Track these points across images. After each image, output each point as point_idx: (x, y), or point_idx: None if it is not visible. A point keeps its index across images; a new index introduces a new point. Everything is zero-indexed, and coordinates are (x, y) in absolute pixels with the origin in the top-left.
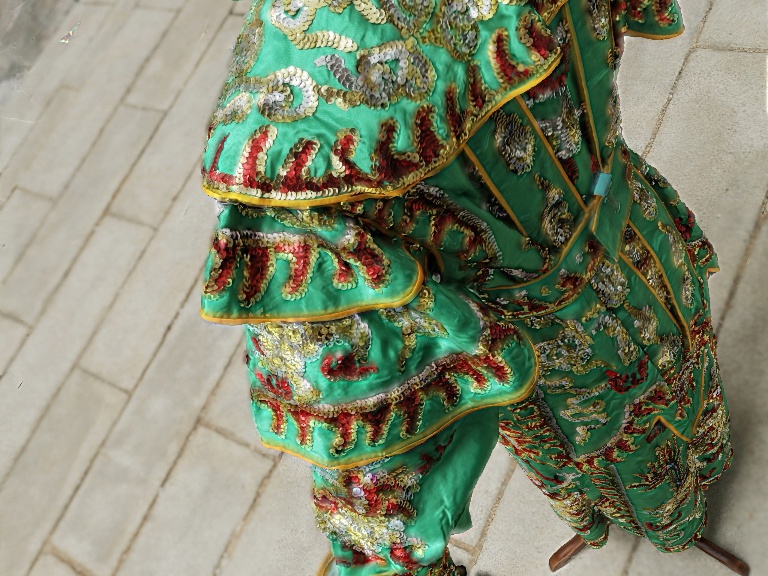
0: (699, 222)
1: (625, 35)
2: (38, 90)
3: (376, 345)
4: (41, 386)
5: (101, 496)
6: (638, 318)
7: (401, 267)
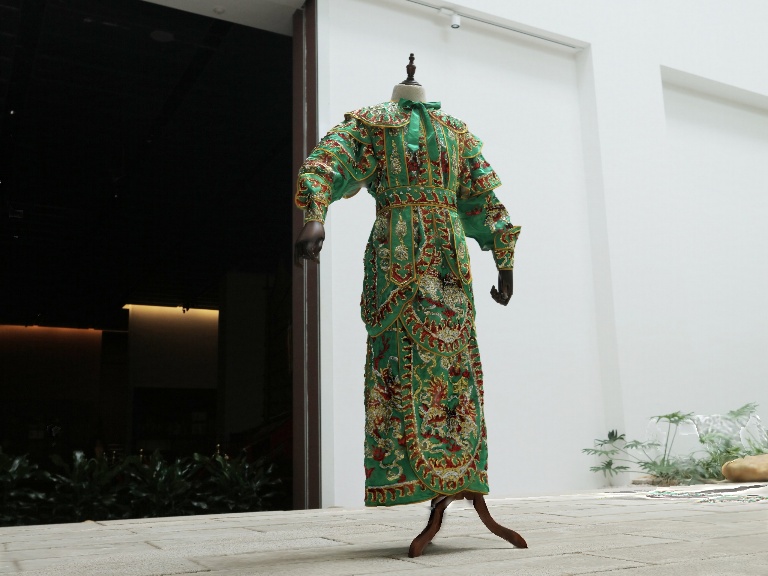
0: (247, 573)
1: None
2: None
3: None
4: None
5: None
6: None
7: None
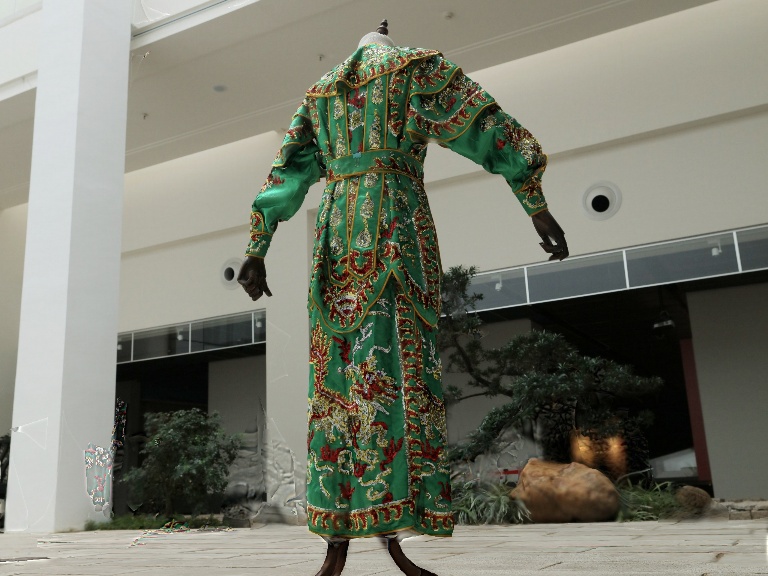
0: None
1: None
2: (761, 521)
3: None
4: None
5: None
6: (334, 209)
7: None
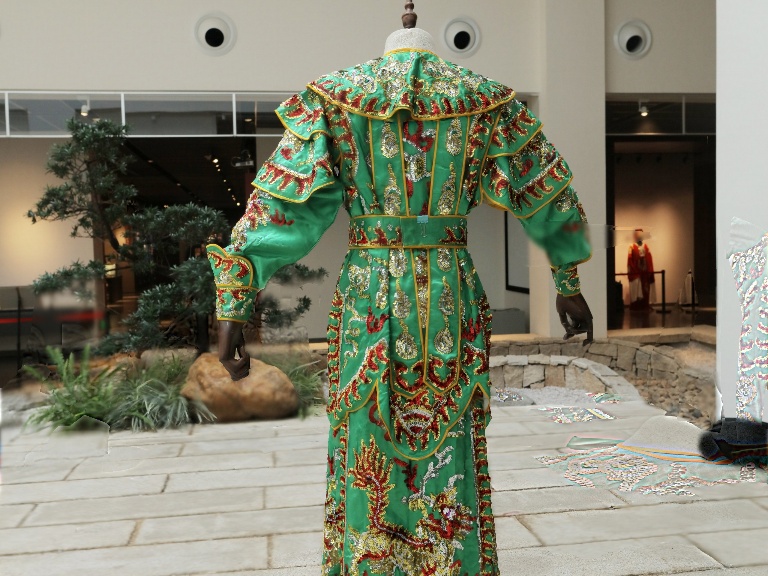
0: None
1: (486, 198)
2: None
3: (299, 154)
4: (241, 482)
5: (188, 523)
6: (398, 293)
7: (321, 124)
